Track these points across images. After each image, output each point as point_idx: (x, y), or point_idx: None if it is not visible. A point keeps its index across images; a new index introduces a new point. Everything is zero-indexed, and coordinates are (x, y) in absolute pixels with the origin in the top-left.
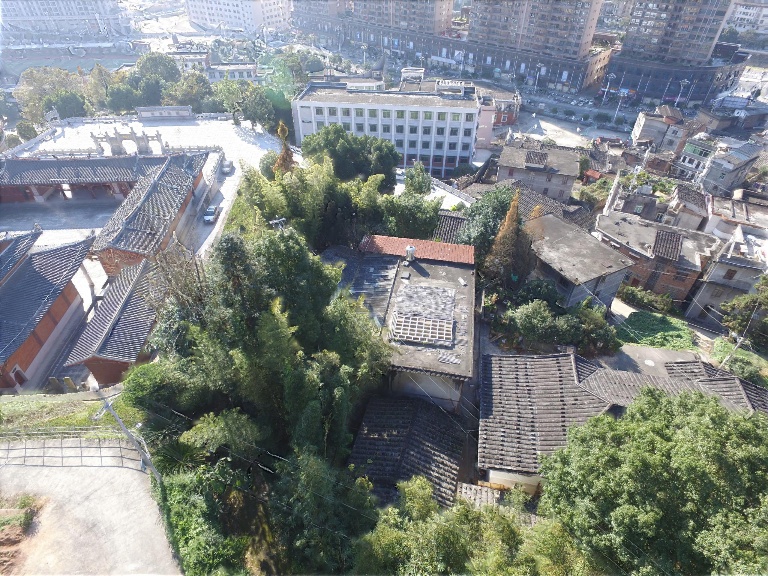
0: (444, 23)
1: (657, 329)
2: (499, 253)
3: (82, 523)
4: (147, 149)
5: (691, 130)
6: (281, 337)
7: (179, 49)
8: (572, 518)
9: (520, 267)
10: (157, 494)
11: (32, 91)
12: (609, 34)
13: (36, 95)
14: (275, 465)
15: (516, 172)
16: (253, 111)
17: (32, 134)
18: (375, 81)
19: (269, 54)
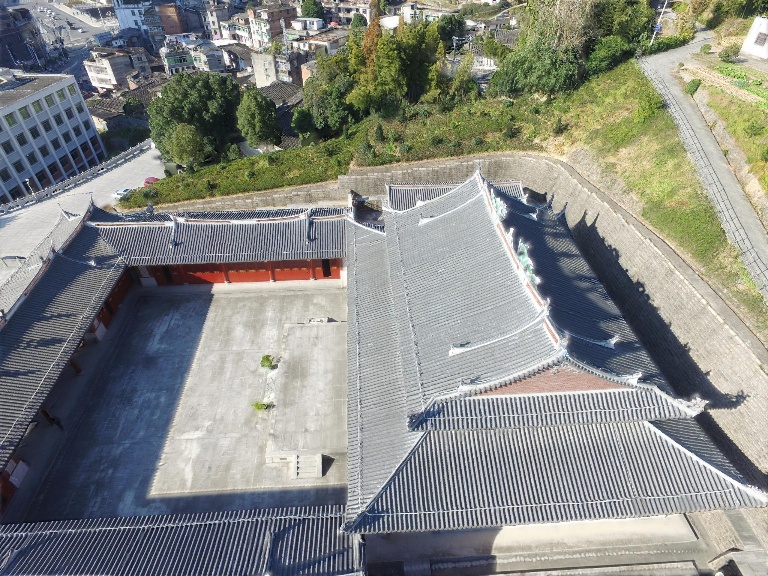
0: None
1: None
2: None
3: (673, 63)
4: None
5: None
6: None
7: None
8: None
9: None
10: None
11: None
12: None
13: None
14: None
15: None
16: None
17: None
18: None
19: None
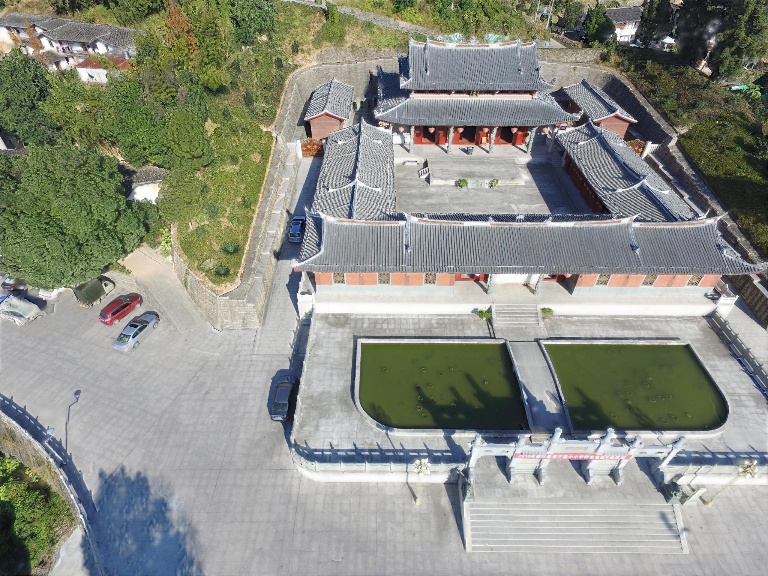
0: None
1: None
2: None
3: None
4: None
5: None
6: None
7: None
8: None
9: None
10: None
11: None
12: None
13: None
14: None
15: None
16: None
17: None
18: None
19: None
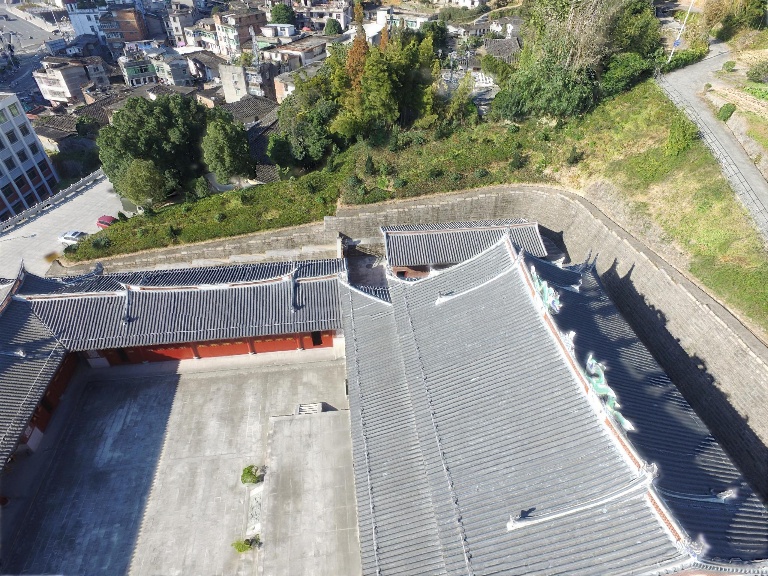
0: None
1: None
2: None
3: (696, 83)
4: None
5: None
6: None
7: None
8: (625, 4)
9: None
10: None
11: None
12: None
13: None
14: None
15: None
16: None
17: None
18: None
19: None
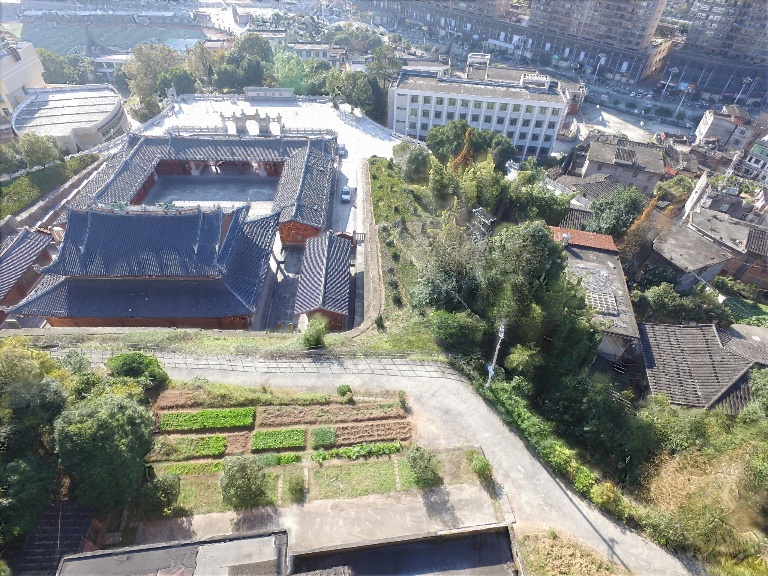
0: (504, 6)
1: (750, 313)
2: (630, 243)
3: (439, 409)
4: (267, 129)
5: (758, 131)
6: (566, 297)
7: (259, 27)
8: None
9: (643, 255)
10: (489, 394)
11: (140, 66)
12: (670, 25)
13: (143, 70)
14: (566, 380)
15: (605, 167)
16: (357, 97)
17: (156, 109)
18: (442, 65)
19: (331, 31)
